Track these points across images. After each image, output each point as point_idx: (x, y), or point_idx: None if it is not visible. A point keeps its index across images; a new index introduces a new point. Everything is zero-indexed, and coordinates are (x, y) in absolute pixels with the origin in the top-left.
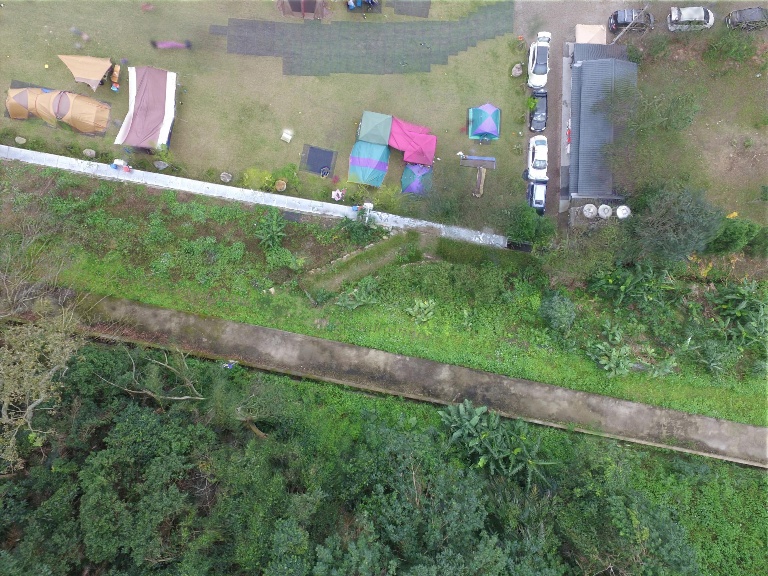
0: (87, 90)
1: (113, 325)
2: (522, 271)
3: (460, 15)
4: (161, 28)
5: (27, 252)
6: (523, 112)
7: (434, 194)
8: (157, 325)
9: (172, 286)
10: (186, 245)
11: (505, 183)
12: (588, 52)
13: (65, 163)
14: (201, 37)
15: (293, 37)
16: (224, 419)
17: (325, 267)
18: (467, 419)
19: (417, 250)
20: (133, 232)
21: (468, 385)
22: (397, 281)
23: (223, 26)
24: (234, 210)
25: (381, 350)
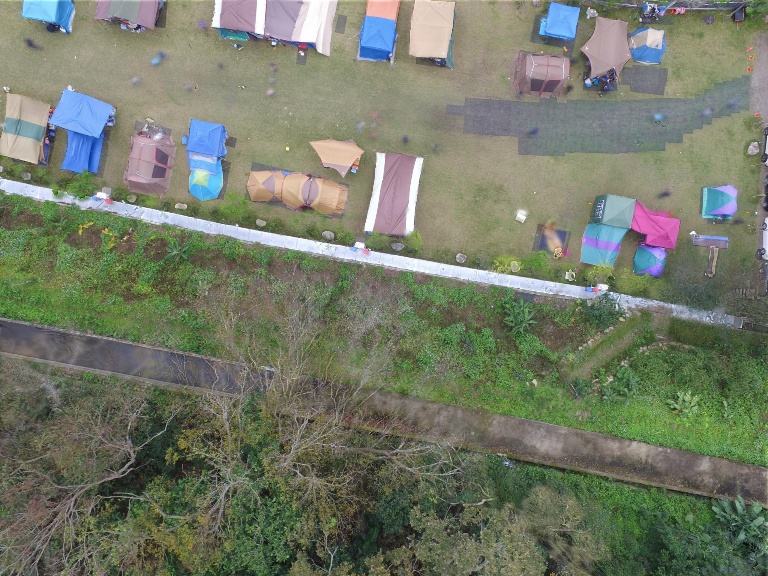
0: (326, 172)
1: (384, 419)
2: (754, 351)
3: (696, 92)
4: (399, 108)
5: (298, 346)
6: (758, 191)
7: (666, 274)
8: (426, 418)
9: (439, 379)
10: (442, 334)
11: (738, 263)
12: None
13: (304, 245)
14: (438, 117)
15: (529, 116)
16: (539, 530)
17: (575, 354)
18: (748, 519)
19: (650, 331)
20: (389, 321)
21: (728, 476)
22: (655, 372)
23: (460, 106)
24: (472, 292)
25: (643, 442)
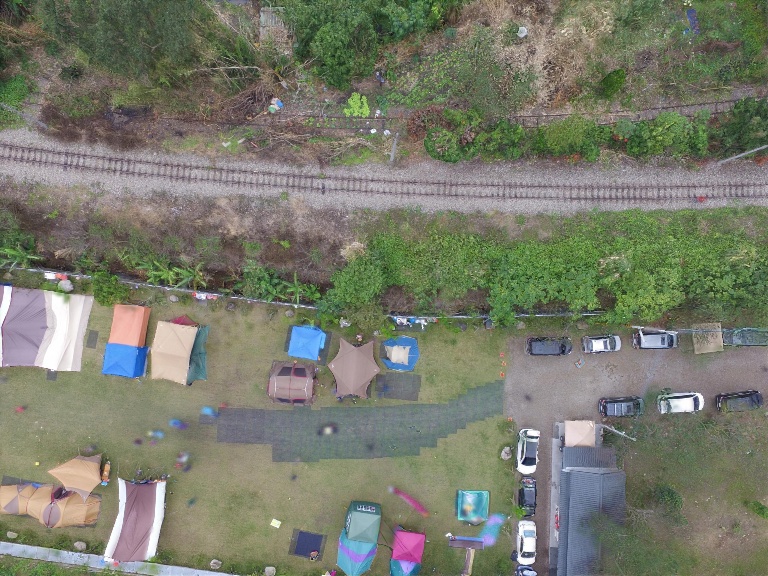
0: None
1: None
2: None
3: (450, 398)
4: (151, 420)
5: None
6: (512, 494)
7: (423, 575)
8: None
9: None
10: None
11: (494, 563)
12: (577, 457)
13: (56, 556)
14: (191, 427)
15: (283, 424)
16: None
17: None
18: None
19: None
20: None
21: None
22: None
23: (213, 415)
24: None
25: None
